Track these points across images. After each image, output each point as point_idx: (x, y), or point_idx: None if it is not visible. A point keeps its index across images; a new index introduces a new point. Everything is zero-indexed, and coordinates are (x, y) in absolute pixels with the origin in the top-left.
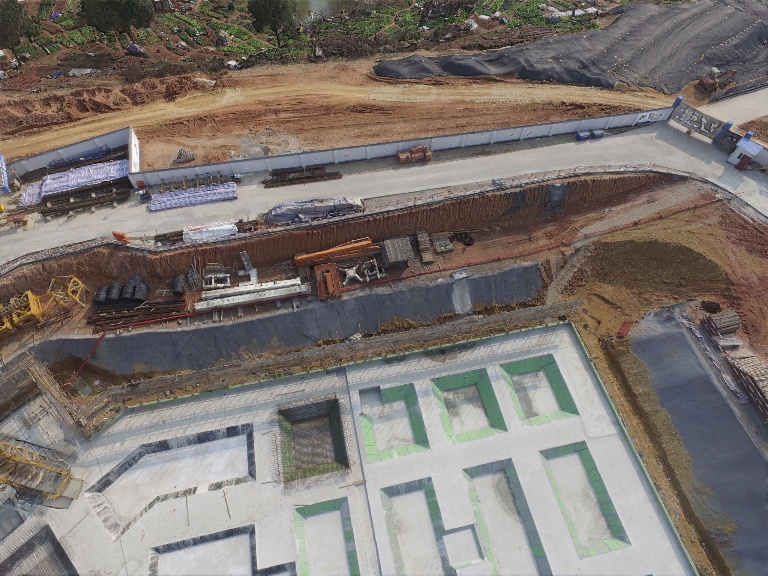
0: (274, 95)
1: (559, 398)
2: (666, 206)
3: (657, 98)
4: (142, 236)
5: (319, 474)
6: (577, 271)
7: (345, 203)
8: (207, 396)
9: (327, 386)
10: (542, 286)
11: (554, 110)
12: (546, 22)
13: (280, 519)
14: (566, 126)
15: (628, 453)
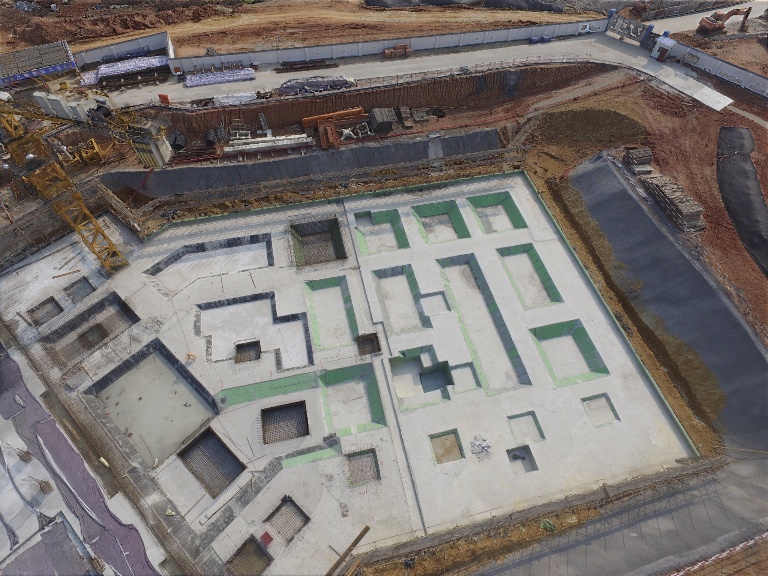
0: (282, 18)
1: (513, 220)
2: (600, 87)
3: (598, 18)
4: (181, 101)
5: (323, 262)
6: (529, 135)
7: (342, 79)
8: (234, 217)
9: (329, 211)
10: (501, 147)
11: (512, 26)
12: None
13: (294, 288)
14: (521, 33)
15: (565, 250)
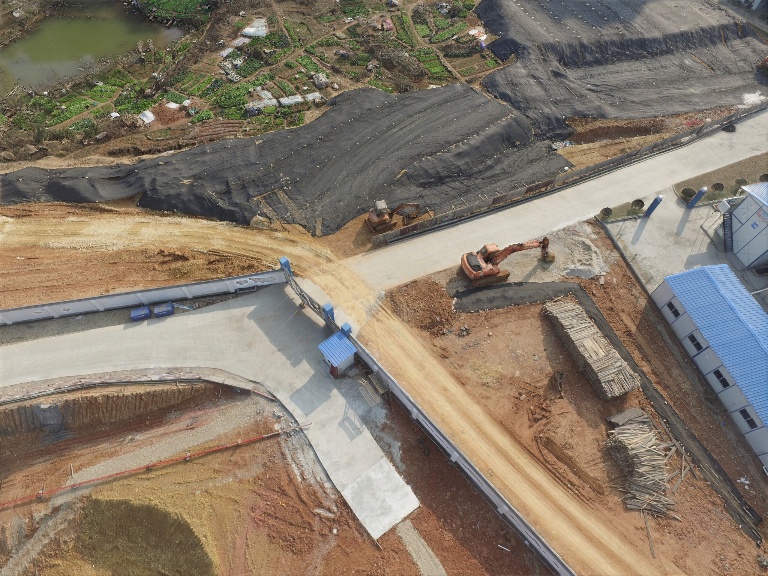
0: None
1: None
2: (203, 439)
3: (298, 243)
4: None
5: None
6: (48, 543)
7: None
8: None
9: None
10: None
11: (142, 263)
12: (242, 115)
13: None
14: (119, 299)
15: None
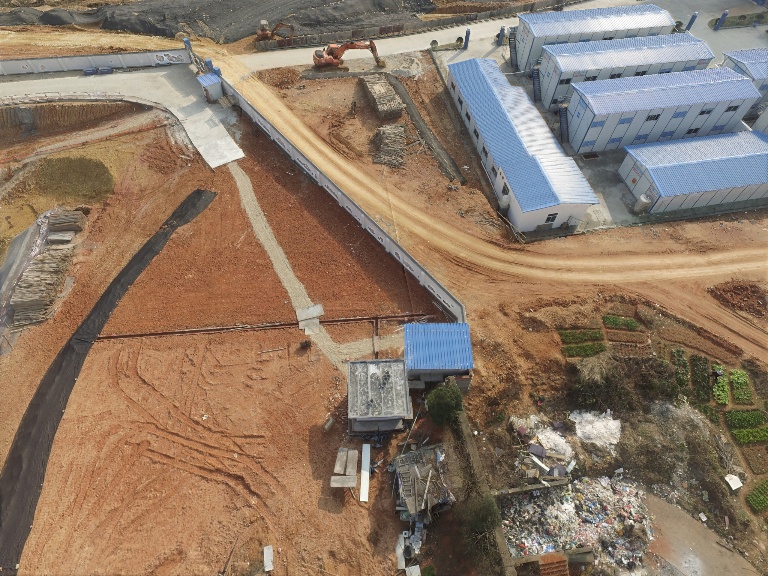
0: None
1: None
2: (119, 130)
3: (205, 46)
4: None
5: None
6: (18, 184)
7: None
8: None
9: None
10: None
11: (97, 52)
12: None
13: None
14: (77, 62)
15: None
